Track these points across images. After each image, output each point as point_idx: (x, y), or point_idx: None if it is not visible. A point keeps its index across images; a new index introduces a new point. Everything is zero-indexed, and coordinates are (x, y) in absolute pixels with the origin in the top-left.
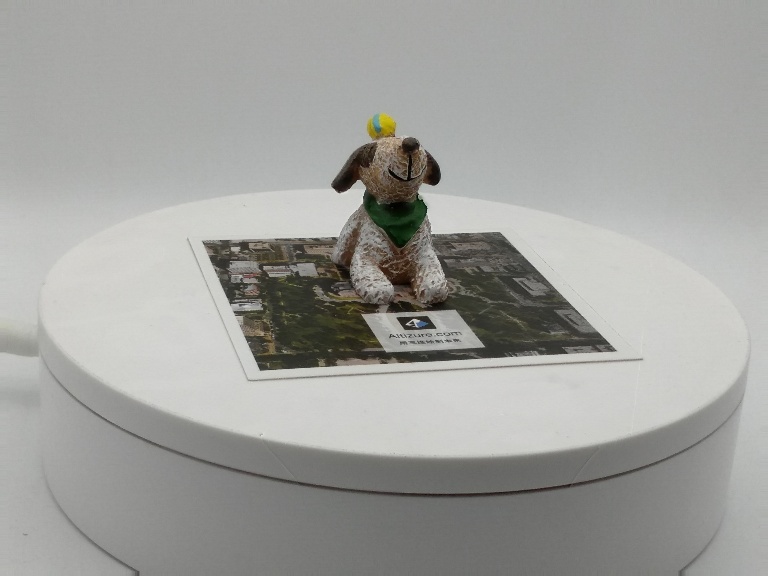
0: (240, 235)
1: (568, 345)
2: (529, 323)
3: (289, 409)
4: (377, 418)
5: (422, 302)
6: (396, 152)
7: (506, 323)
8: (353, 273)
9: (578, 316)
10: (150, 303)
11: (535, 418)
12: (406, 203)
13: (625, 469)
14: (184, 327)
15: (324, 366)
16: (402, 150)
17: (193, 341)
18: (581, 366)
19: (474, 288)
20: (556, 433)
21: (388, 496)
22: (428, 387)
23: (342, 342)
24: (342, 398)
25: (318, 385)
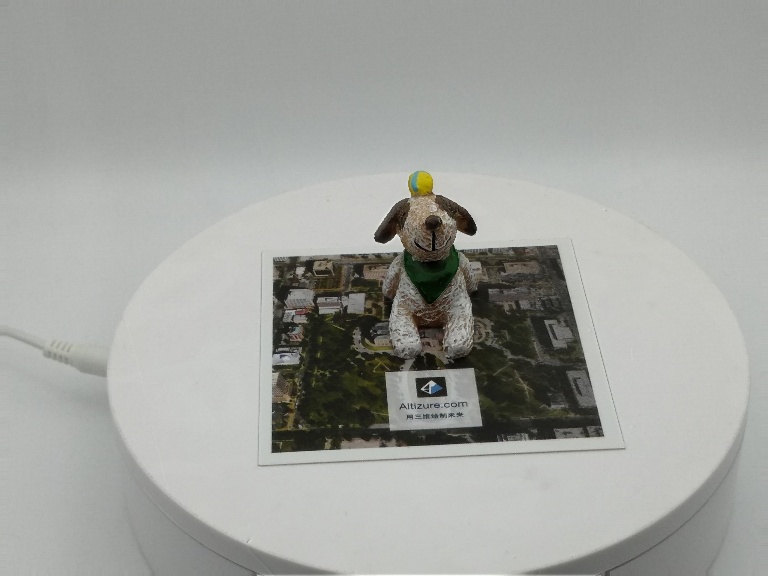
0: (310, 249)
1: (561, 426)
2: (535, 391)
3: (282, 507)
4: (354, 523)
5: (446, 356)
6: (420, 228)
7: (514, 390)
8: (389, 320)
9: (586, 381)
10: (204, 350)
11: (494, 530)
12: (438, 261)
13: None
14: (224, 386)
15: (328, 449)
16: (425, 227)
17: (227, 407)
18: (564, 455)
19: (502, 335)
20: (505, 553)
21: None
22: (413, 481)
23: (355, 414)
24: (332, 494)
25: (317, 474)
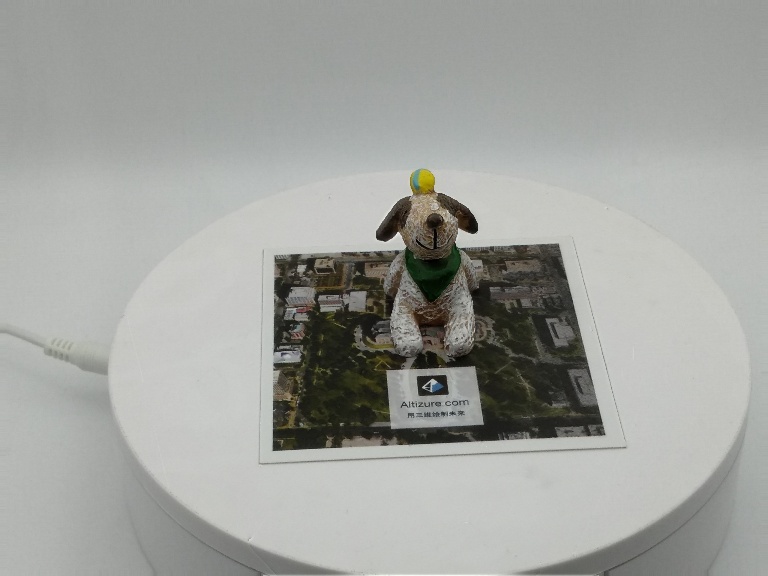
0: (311, 247)
1: (562, 424)
2: (537, 389)
3: (283, 505)
4: (355, 522)
5: (447, 355)
6: (422, 226)
7: (515, 389)
8: (391, 318)
9: (588, 380)
10: (205, 348)
11: (495, 528)
12: (439, 259)
13: None
14: (225, 384)
15: (330, 447)
16: (427, 225)
17: (228, 405)
18: (565, 454)
19: (503, 333)
20: (506, 551)
21: None
22: (414, 479)
23: (356, 413)
24: (333, 492)
25: (318, 472)
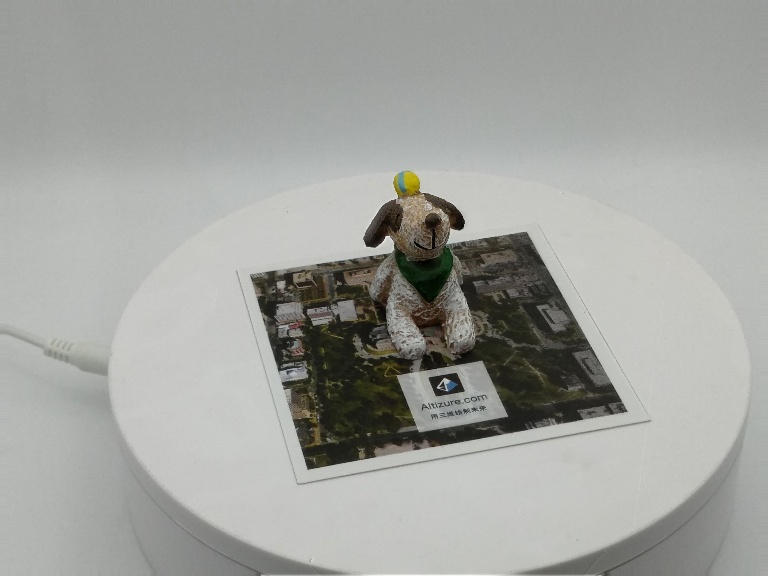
0: (285, 262)
1: (583, 406)
2: (549, 376)
3: (334, 522)
4: (411, 529)
5: (452, 353)
6: (420, 227)
7: (528, 378)
8: (388, 323)
9: (594, 360)
10: (207, 376)
11: (549, 516)
12: (433, 259)
13: (629, 557)
14: (239, 410)
15: (364, 458)
16: (425, 226)
17: (248, 429)
18: (594, 435)
19: (500, 325)
20: (567, 537)
21: None
22: (456, 479)
23: (379, 421)
24: (380, 502)
25: (359, 485)
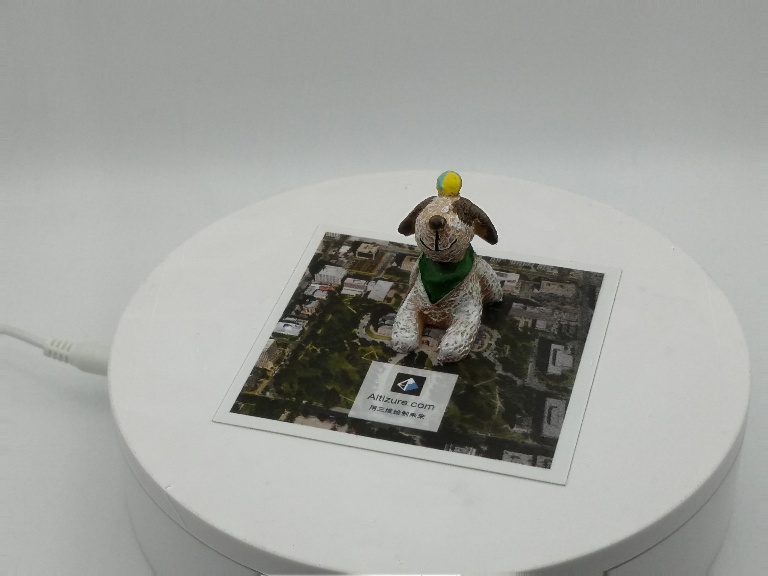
0: (364, 231)
1: (513, 449)
2: (506, 410)
3: (213, 464)
4: (269, 494)
5: (437, 358)
6: (425, 226)
7: (486, 405)
8: None
9: (561, 412)
10: (220, 305)
11: (396, 532)
12: (448, 263)
13: None
14: (220, 342)
15: (282, 420)
16: (429, 226)
17: (213, 361)
18: (501, 478)
19: (503, 349)
20: (394, 556)
21: (244, 567)
22: (345, 468)
23: (323, 394)
24: (264, 462)
25: (261, 441)
